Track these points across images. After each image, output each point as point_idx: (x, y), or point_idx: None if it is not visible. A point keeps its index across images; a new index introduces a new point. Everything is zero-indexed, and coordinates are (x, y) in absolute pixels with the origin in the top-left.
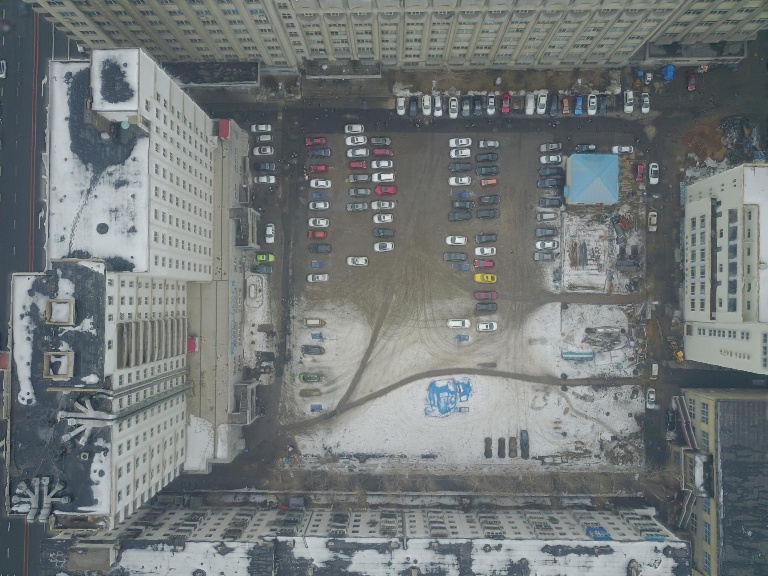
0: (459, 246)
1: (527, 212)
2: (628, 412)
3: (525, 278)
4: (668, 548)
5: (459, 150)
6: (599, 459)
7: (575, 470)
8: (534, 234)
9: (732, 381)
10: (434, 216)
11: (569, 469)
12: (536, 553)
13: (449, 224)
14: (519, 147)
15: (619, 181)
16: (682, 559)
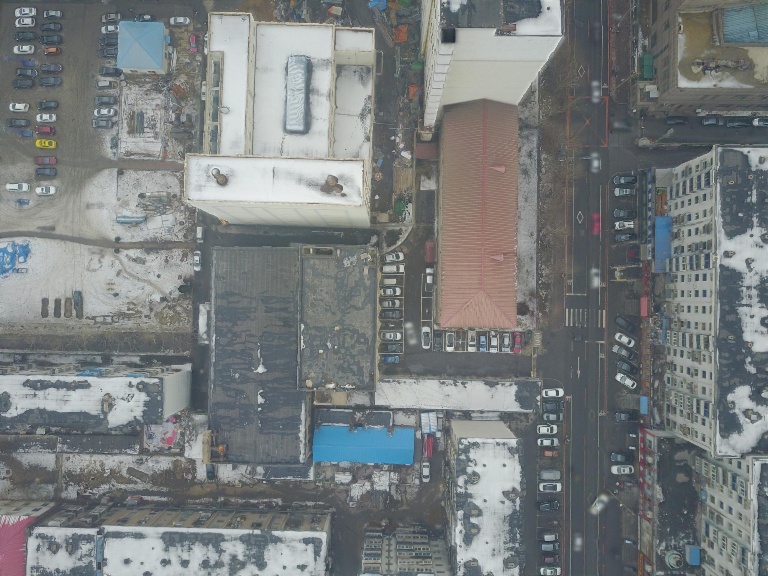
0: (22, 113)
1: (89, 81)
2: (178, 274)
3: (85, 145)
4: (141, 383)
5: (21, 19)
6: (149, 319)
7: (126, 330)
8: (94, 102)
9: (272, 244)
10: (0, 84)
11: (120, 328)
12: (17, 387)
13: (14, 92)
14: (83, 18)
15: (177, 52)
16: (154, 394)
